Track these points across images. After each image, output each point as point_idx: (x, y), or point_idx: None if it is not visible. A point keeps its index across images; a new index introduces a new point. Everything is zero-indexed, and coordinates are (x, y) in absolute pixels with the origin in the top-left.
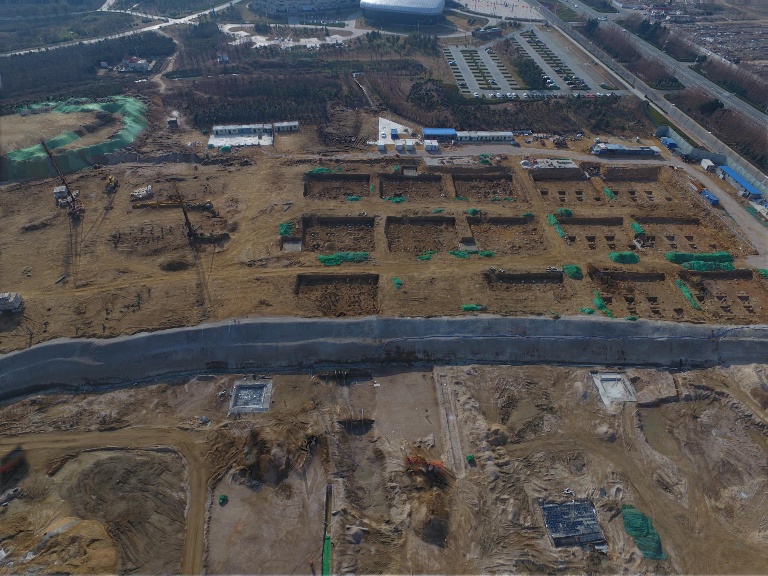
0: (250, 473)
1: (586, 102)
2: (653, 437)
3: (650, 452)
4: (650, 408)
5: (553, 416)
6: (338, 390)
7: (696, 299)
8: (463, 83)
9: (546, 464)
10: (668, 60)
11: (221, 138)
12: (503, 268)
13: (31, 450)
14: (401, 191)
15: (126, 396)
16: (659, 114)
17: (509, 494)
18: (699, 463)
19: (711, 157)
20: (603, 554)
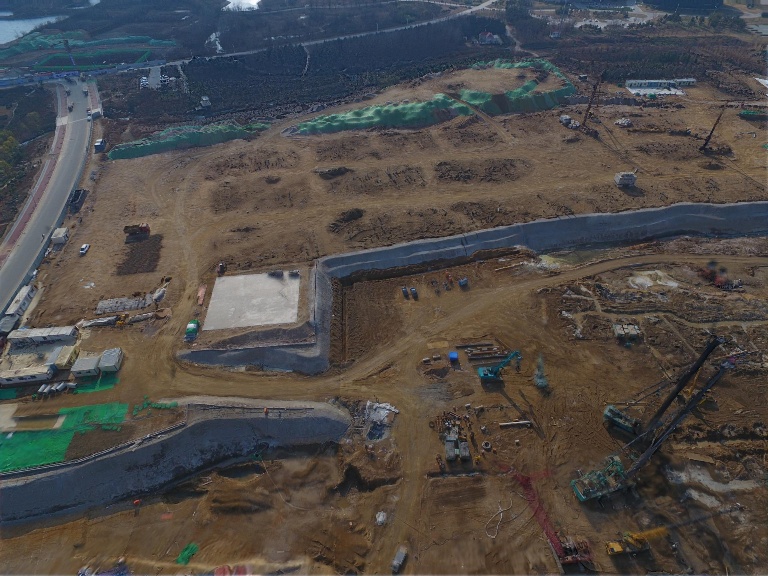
0: None
1: None
2: None
3: None
4: None
5: None
6: None
7: None
8: None
9: None
10: None
11: (637, 89)
12: None
13: (723, 262)
14: None
15: (751, 241)
16: None
17: None
18: None
19: None
20: None
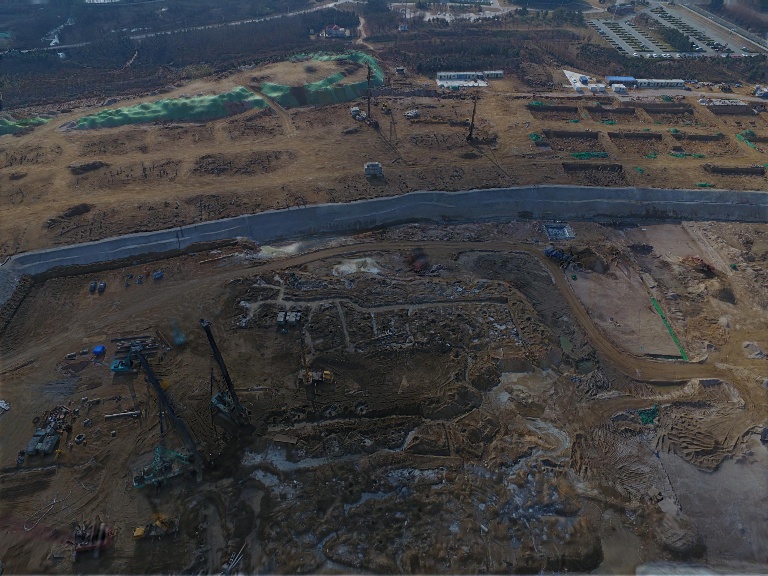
0: (585, 266)
1: (737, 60)
2: None
3: None
4: None
5: None
6: (616, 232)
7: None
8: (620, 47)
9: None
10: None
11: (445, 81)
12: (716, 164)
13: (434, 248)
14: (606, 119)
15: (475, 226)
16: None
17: None
18: None
19: None
20: None
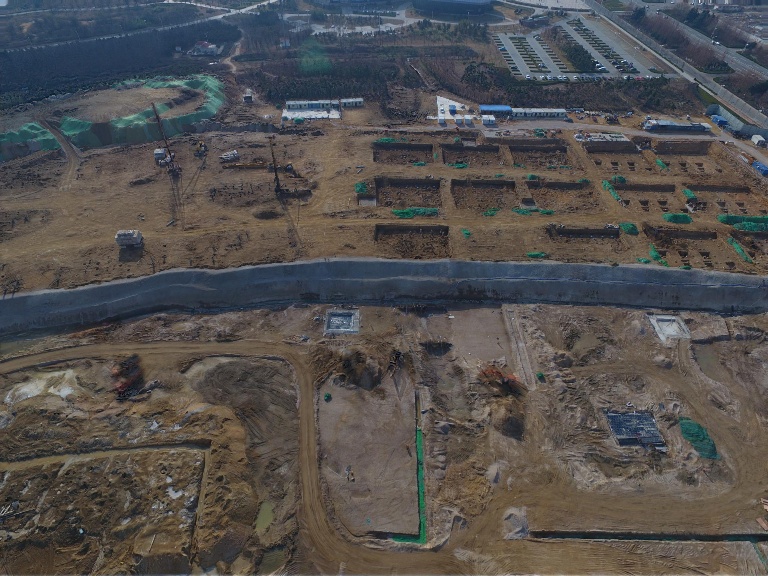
0: (349, 378)
1: (636, 83)
2: (707, 367)
3: (704, 378)
4: (703, 344)
5: (613, 346)
6: (417, 320)
7: (747, 254)
8: (514, 66)
9: (609, 383)
10: (717, 46)
11: (293, 112)
12: (563, 224)
13: (164, 353)
14: (462, 159)
15: (236, 317)
16: (709, 95)
17: (576, 404)
18: (750, 389)
19: (762, 133)
20: (663, 453)
